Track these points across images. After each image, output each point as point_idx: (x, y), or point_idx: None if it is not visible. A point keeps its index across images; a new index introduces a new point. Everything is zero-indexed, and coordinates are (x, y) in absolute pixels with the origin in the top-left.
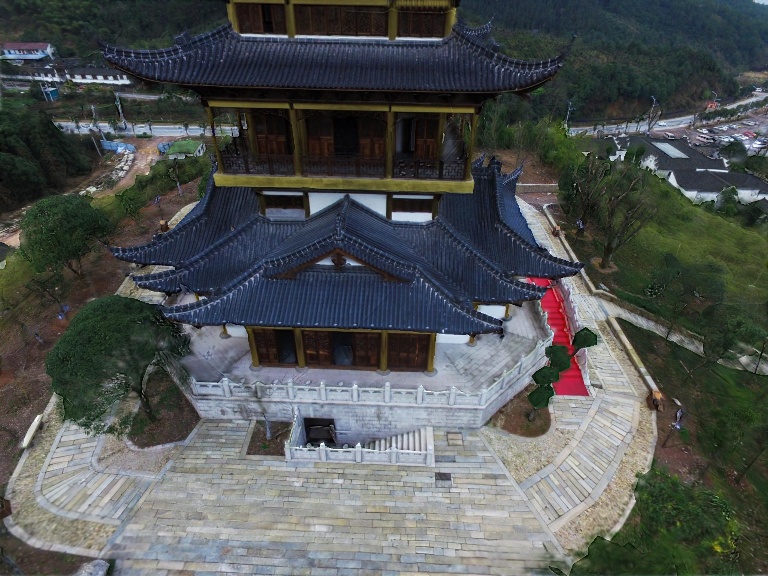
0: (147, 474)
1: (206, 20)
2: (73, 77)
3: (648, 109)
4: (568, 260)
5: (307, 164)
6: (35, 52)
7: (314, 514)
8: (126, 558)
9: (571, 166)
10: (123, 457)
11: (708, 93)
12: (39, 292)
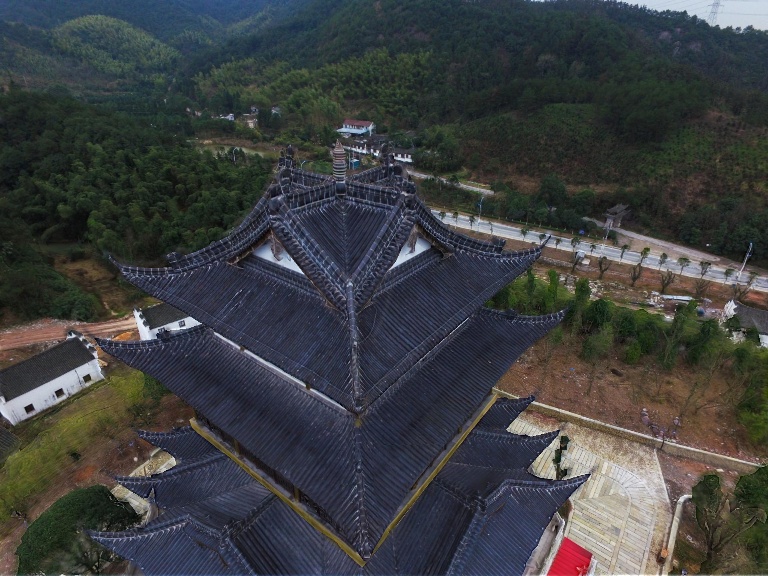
0: None
1: (494, 112)
2: (375, 151)
3: None
4: None
5: (243, 449)
6: (362, 128)
7: None
8: None
9: (711, 480)
10: None
11: None
12: None
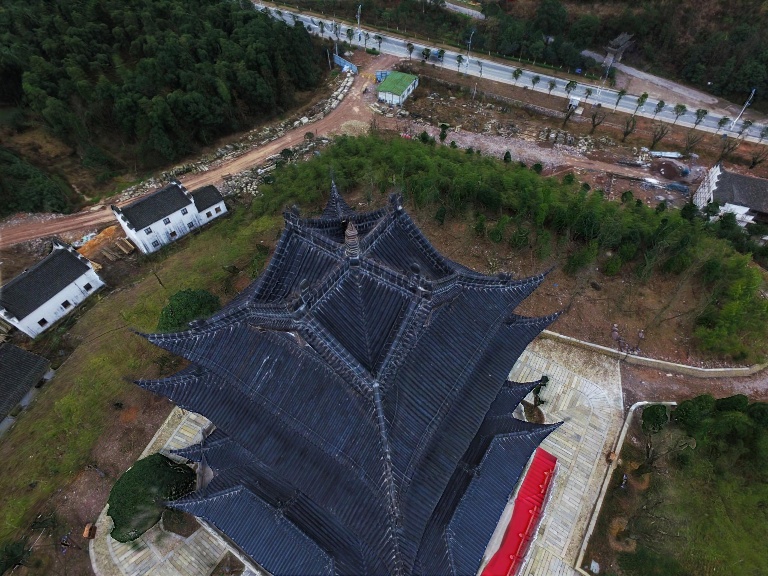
0: (158, 554)
1: None
2: None
3: None
4: (591, 504)
5: None
6: None
7: None
8: None
9: (660, 410)
10: (154, 531)
11: None
12: (160, 366)
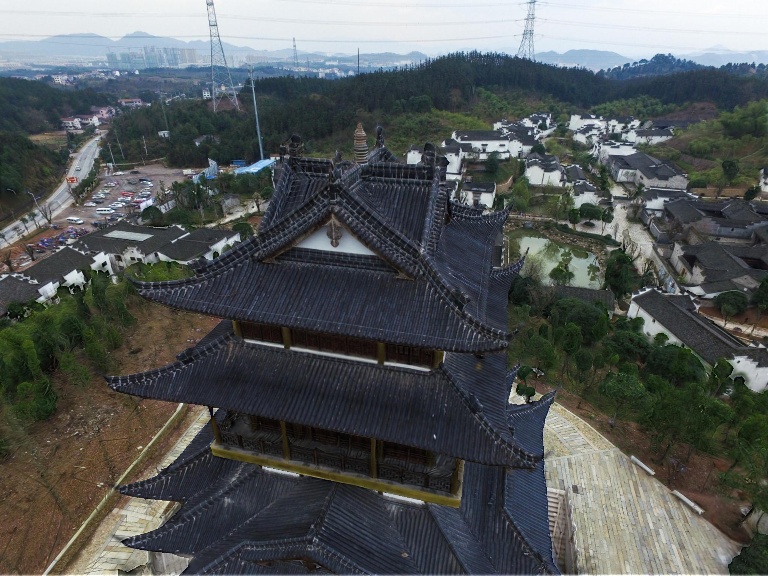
0: None
1: None
2: None
3: (14, 202)
4: None
5: None
6: None
7: (620, 572)
8: None
9: None
10: None
11: (46, 169)
12: None
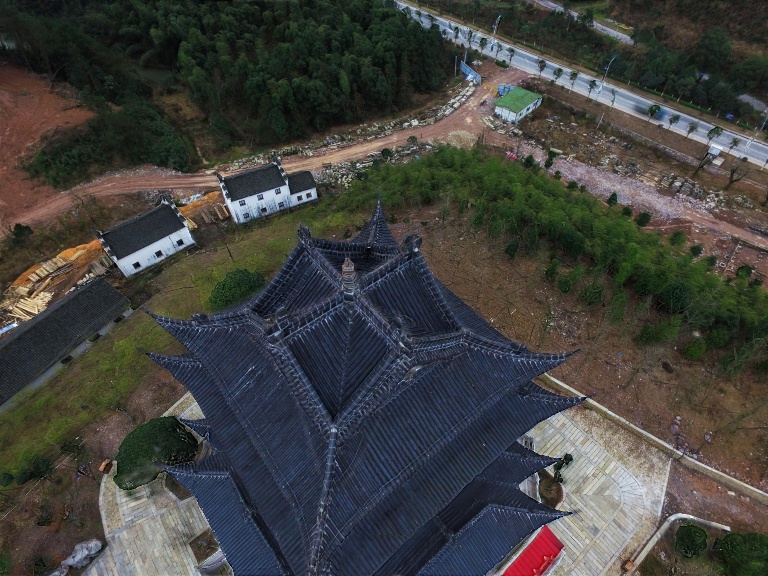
0: (153, 507)
1: None
2: None
3: None
4: None
5: None
6: None
7: None
8: (110, 549)
9: (698, 535)
10: (156, 484)
11: None
12: None
